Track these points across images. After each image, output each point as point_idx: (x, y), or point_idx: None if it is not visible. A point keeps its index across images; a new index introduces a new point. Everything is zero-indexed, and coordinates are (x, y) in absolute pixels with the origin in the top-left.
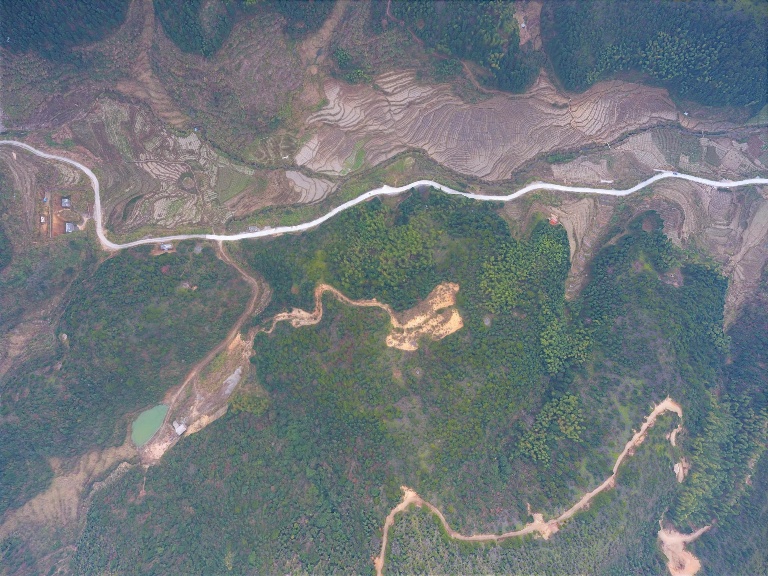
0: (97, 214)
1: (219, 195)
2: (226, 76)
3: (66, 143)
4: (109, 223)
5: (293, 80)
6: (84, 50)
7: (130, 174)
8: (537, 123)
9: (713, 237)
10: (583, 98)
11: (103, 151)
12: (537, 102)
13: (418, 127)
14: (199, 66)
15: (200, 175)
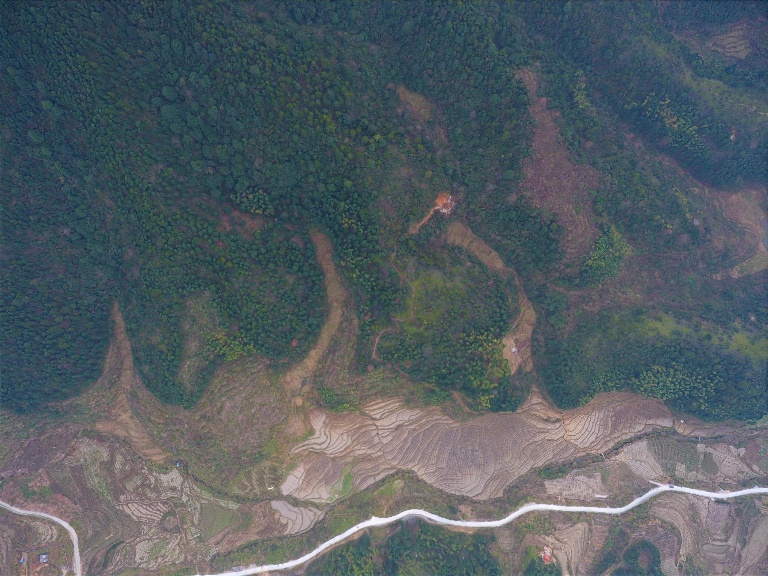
0: (76, 565)
1: (203, 533)
2: (208, 423)
3: (43, 492)
4: (89, 572)
5: (277, 415)
6: (60, 404)
7: (110, 521)
8: (529, 438)
9: (711, 554)
10: (576, 412)
11: (82, 496)
12: (529, 416)
13: (407, 449)
14: (180, 415)
15: (183, 512)
